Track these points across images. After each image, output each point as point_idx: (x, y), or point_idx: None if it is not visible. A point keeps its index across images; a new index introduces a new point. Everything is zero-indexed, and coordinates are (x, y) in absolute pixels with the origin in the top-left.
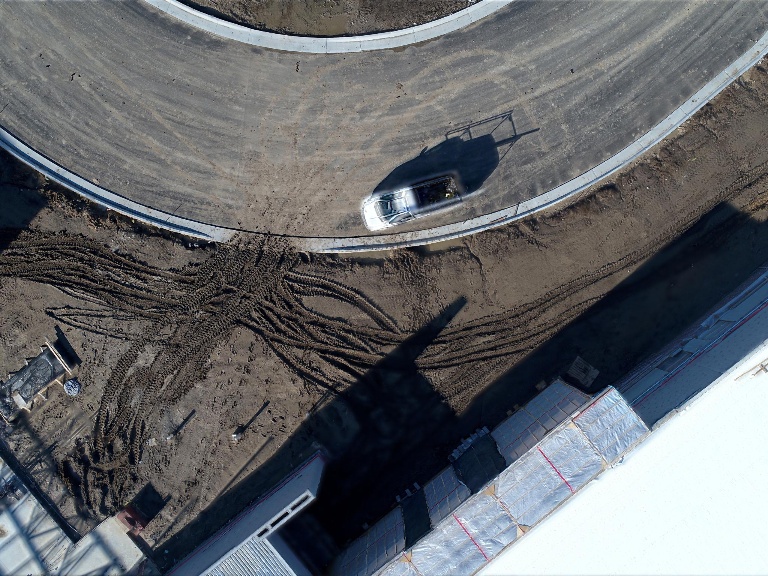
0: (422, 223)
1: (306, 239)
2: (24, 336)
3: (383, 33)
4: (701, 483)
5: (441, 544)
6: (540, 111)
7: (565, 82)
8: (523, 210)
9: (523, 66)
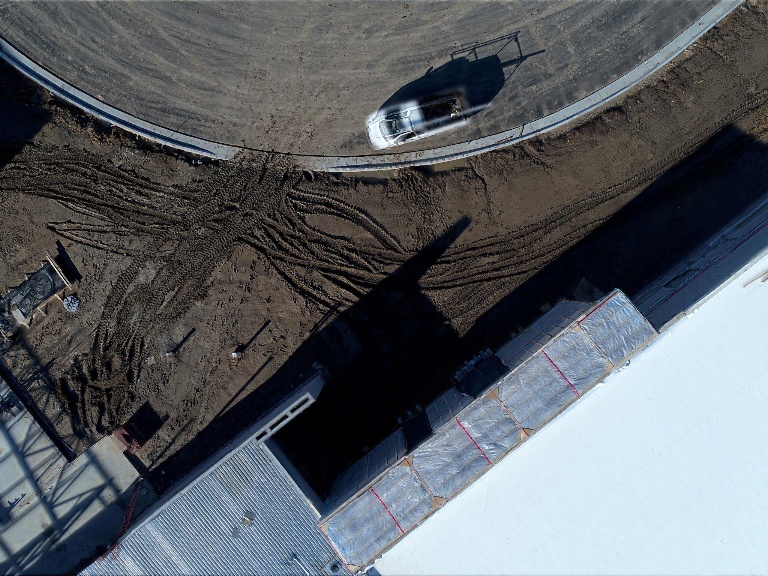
0: (427, 143)
1: (310, 157)
2: (25, 251)
3: None
4: (710, 393)
5: (443, 448)
6: (546, 32)
7: (571, 4)
8: (528, 131)
9: None
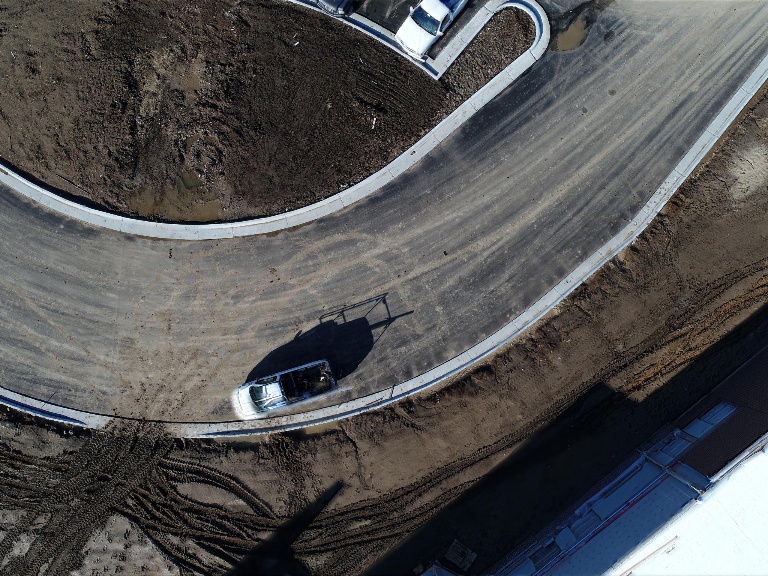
0: (297, 407)
1: (181, 425)
2: None
3: (255, 220)
4: None
5: None
6: (414, 293)
7: (438, 264)
8: (398, 392)
9: (396, 249)
